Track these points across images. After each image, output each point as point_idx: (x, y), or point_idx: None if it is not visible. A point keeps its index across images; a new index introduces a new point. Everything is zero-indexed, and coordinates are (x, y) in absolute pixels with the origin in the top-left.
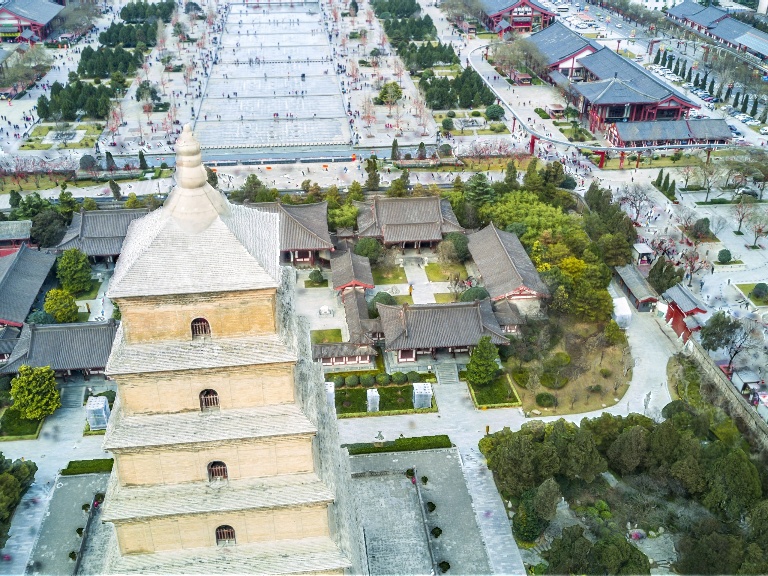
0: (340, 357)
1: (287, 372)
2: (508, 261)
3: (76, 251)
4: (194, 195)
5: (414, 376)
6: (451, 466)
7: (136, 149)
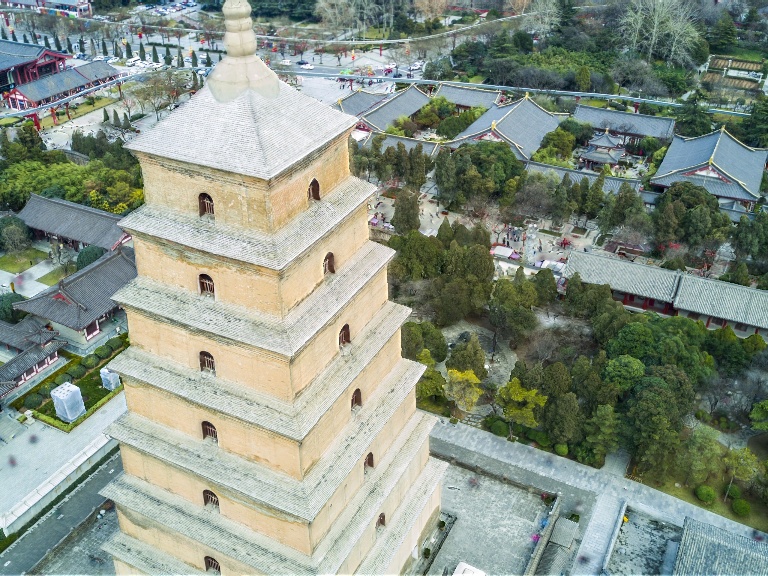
0: (31, 367)
1: None
2: (91, 215)
3: None
4: (256, 60)
5: (116, 342)
6: None
7: None
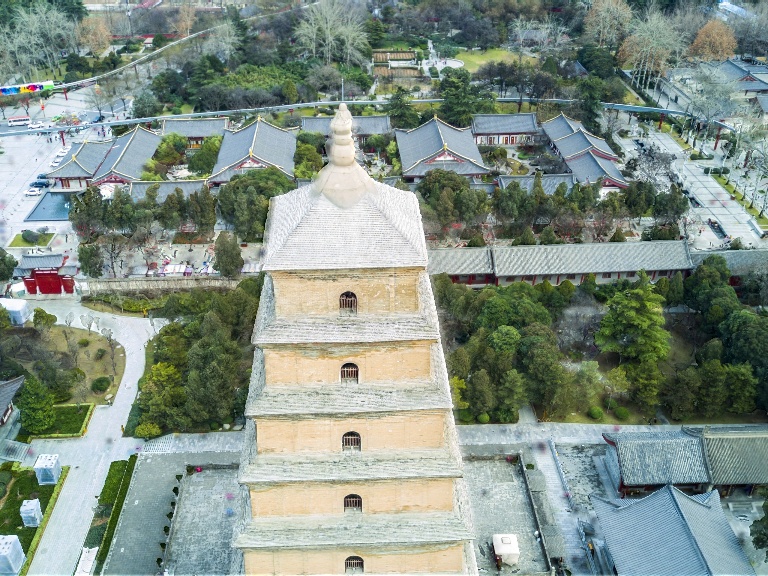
0: None
1: None
2: None
3: None
4: None
5: (6, 475)
6: (163, 460)
7: None
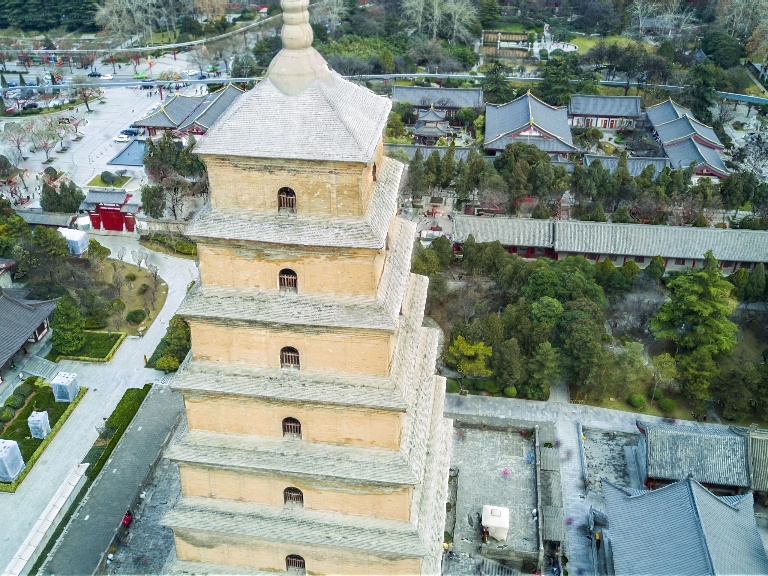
0: None
1: None
2: None
3: None
4: (313, 51)
5: (27, 388)
6: (175, 393)
7: None
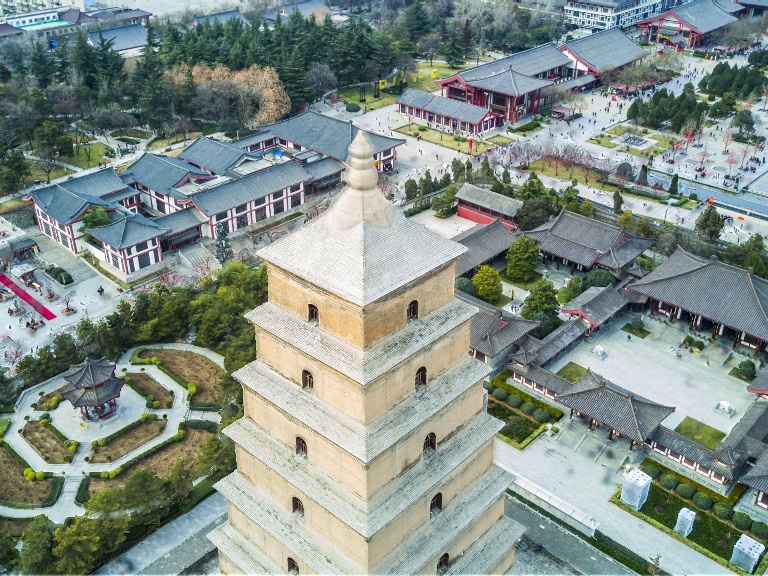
0: (690, 459)
1: (362, 392)
2: None
3: (529, 241)
4: (352, 195)
5: (760, 529)
6: None
7: (689, 173)
